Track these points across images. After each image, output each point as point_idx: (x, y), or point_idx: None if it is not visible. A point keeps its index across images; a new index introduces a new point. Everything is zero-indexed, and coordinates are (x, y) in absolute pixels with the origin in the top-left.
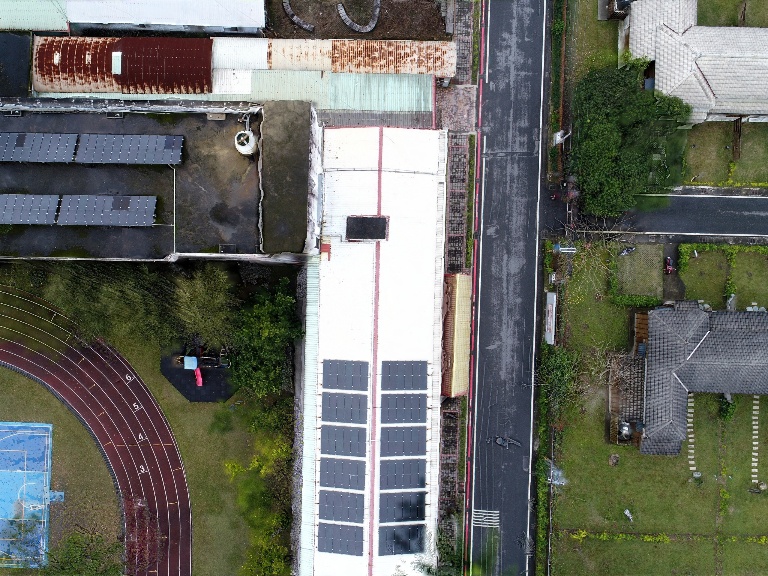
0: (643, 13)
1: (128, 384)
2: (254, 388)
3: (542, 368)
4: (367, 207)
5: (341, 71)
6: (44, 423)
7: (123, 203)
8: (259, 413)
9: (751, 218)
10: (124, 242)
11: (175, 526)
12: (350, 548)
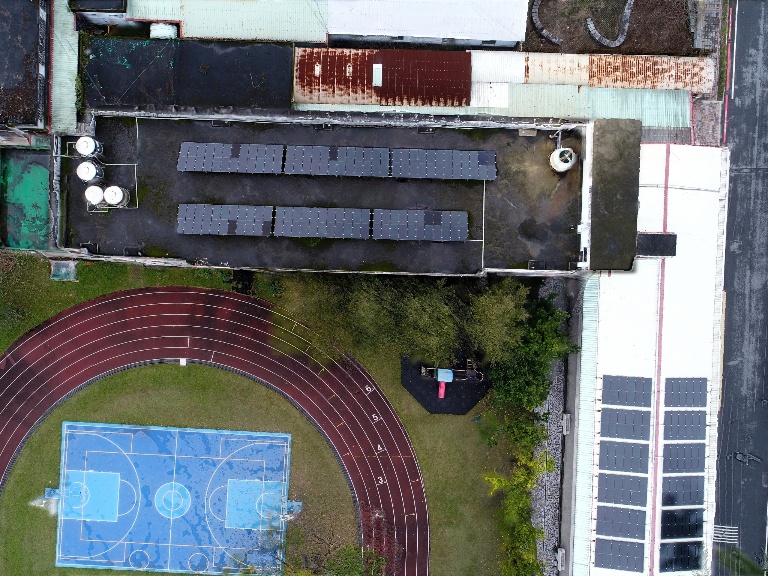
0: None
1: (368, 395)
2: (523, 402)
3: None
4: (652, 224)
5: (597, 86)
6: (283, 433)
7: (435, 218)
8: (499, 426)
9: None
10: (432, 257)
11: (412, 538)
12: (630, 564)
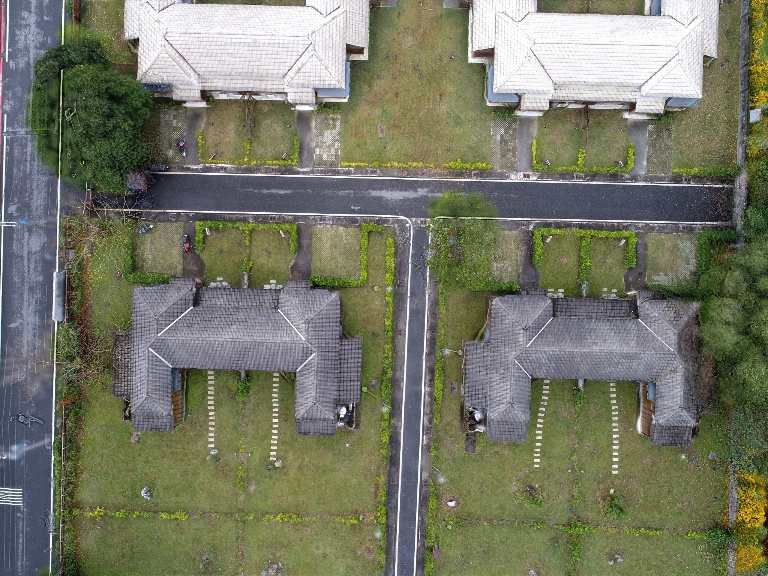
0: None
1: None
2: None
3: (63, 346)
4: None
5: None
6: None
7: None
8: None
9: (270, 196)
10: None
11: None
12: None
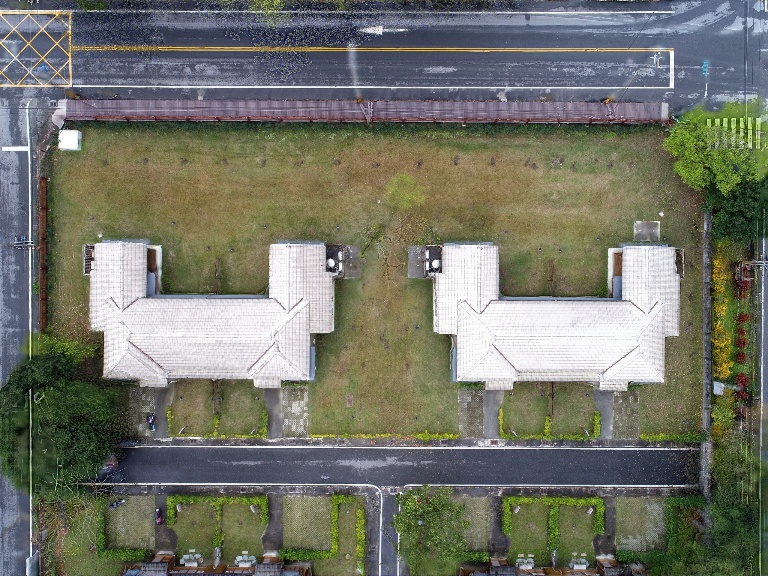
0: (98, 283)
1: None
2: None
3: None
4: None
5: None
6: None
7: None
8: None
9: (240, 467)
10: None
11: None
12: None
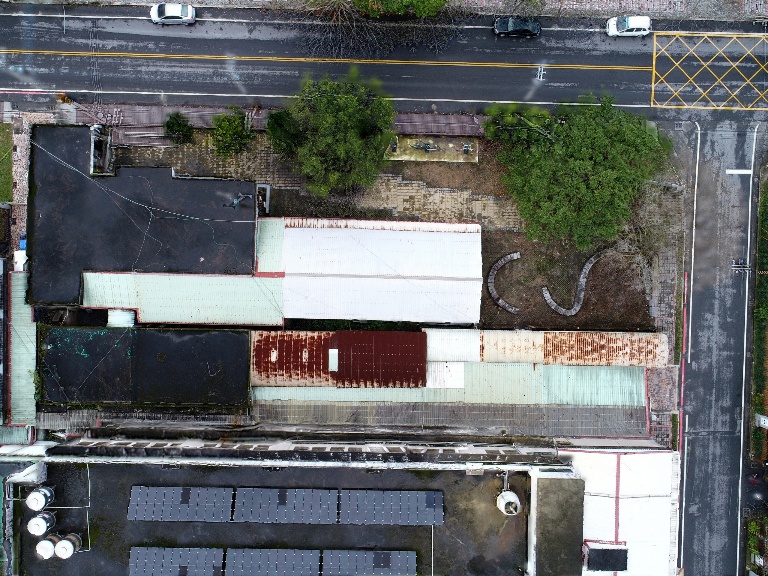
0: None
1: None
2: None
3: None
4: (604, 533)
5: (553, 363)
6: None
7: (384, 560)
8: None
9: None
10: None
11: None
12: None
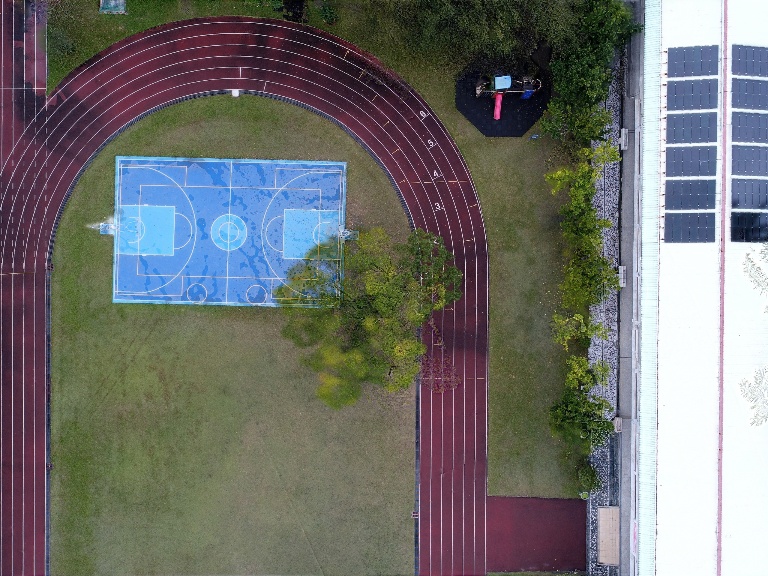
0: None
1: (422, 120)
2: (586, 90)
3: None
4: None
5: None
6: (338, 161)
7: None
8: (555, 147)
9: None
10: None
11: (471, 263)
12: (701, 235)
